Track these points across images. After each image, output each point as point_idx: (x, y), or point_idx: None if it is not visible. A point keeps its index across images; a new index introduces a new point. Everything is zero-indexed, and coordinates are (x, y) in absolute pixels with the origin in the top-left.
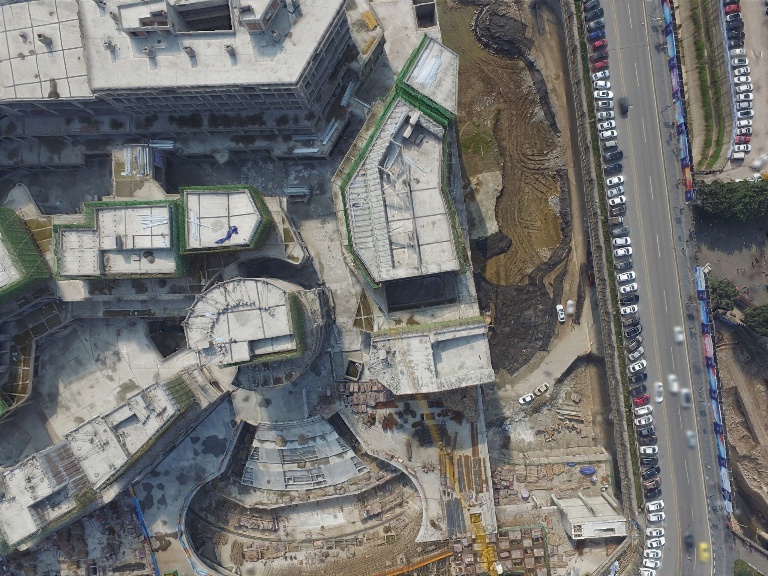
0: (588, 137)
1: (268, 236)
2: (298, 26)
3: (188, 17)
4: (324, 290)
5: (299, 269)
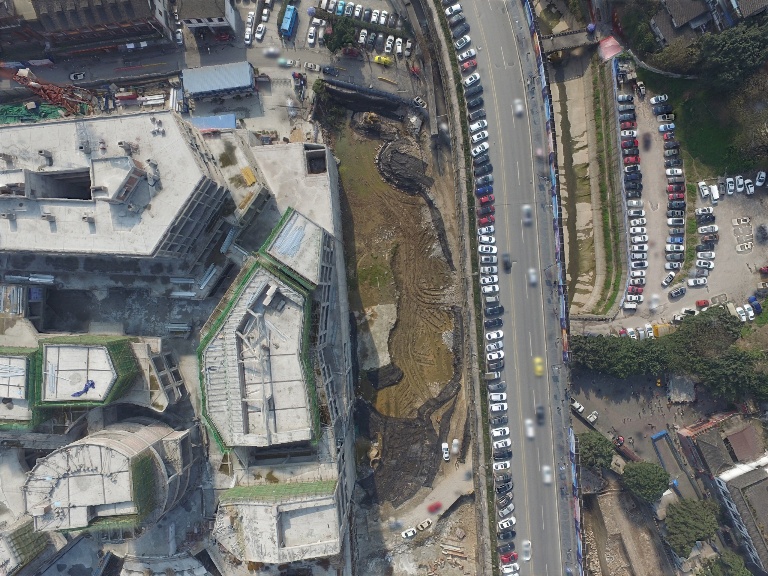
0: (470, 290)
1: (134, 383)
2: (157, 199)
3: (57, 177)
4: (199, 426)
5: (175, 404)
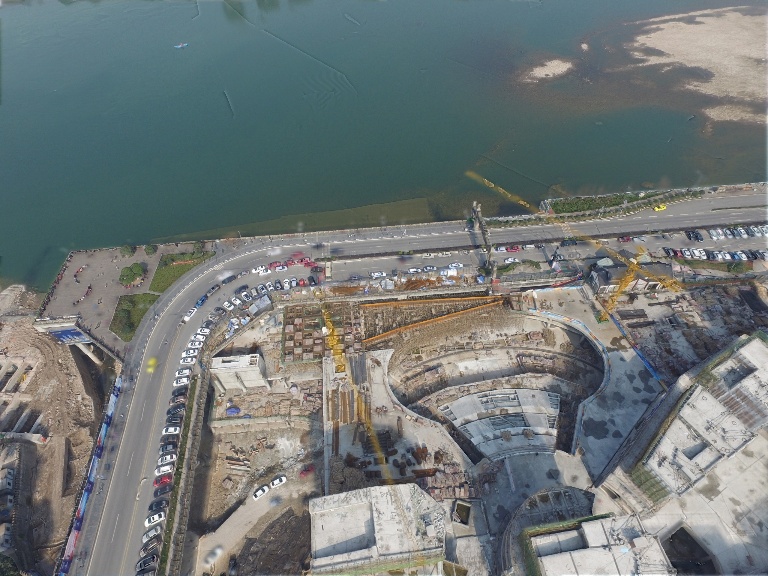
0: None
1: None
2: None
3: None
4: None
5: None
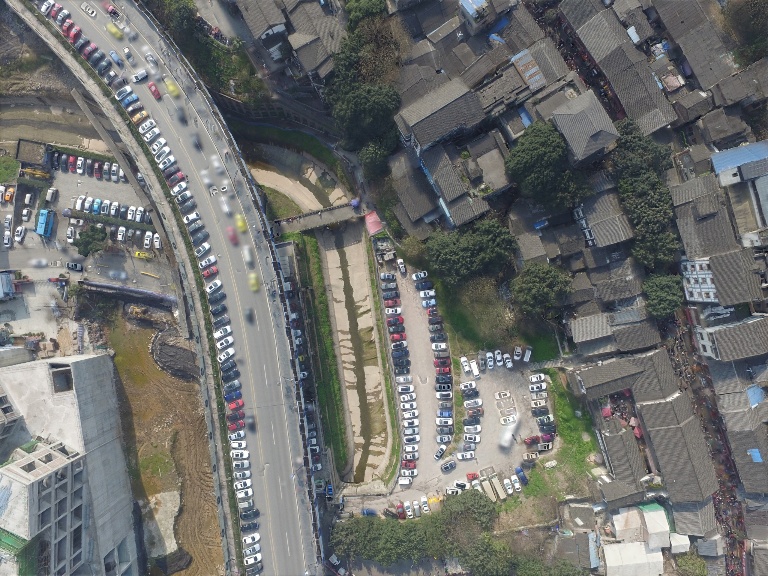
0: (225, 495)
1: None
2: None
3: None
4: None
5: None
